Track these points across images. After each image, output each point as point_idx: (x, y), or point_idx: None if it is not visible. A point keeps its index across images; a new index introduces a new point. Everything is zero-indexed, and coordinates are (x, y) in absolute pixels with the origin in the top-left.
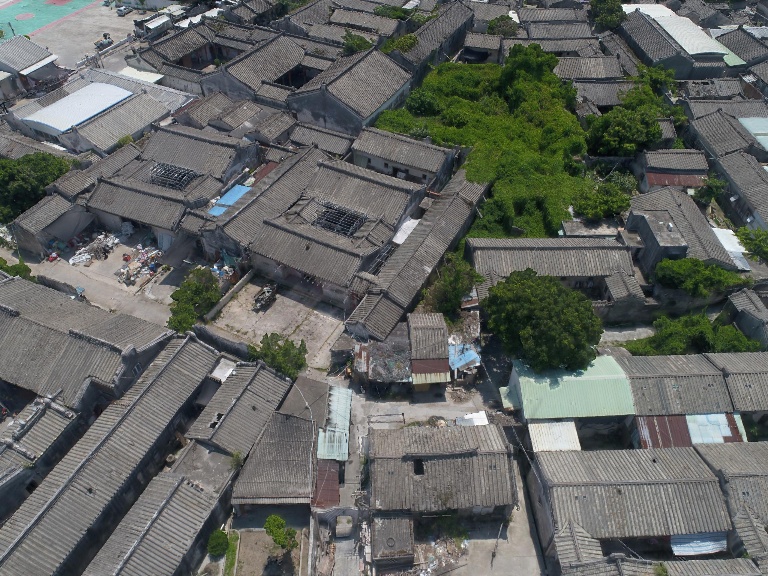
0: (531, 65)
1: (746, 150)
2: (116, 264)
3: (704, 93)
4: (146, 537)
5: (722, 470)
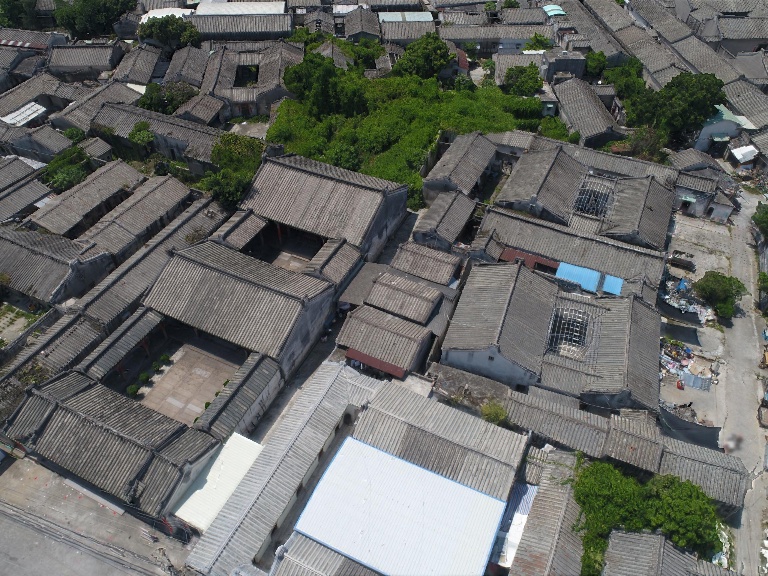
0: (331, 69)
1: None
2: (693, 395)
3: (331, 28)
4: None
5: None
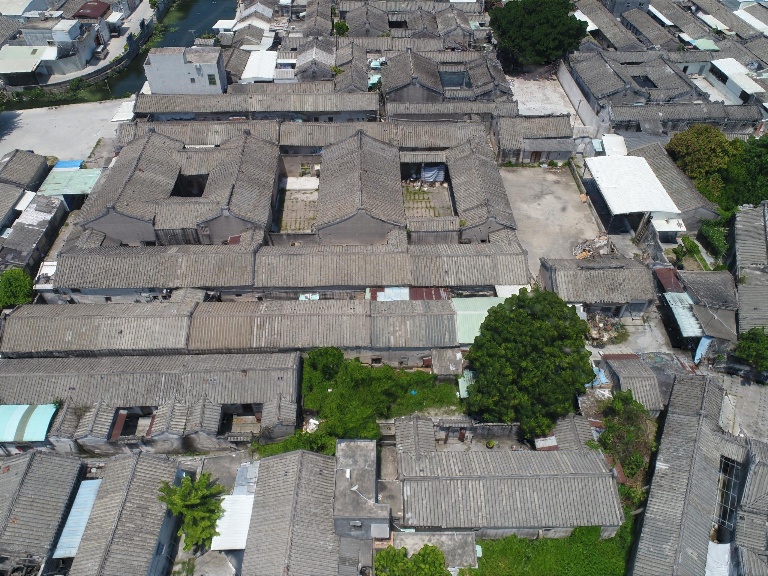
0: None
1: None
2: None
3: None
4: (765, 239)
5: None
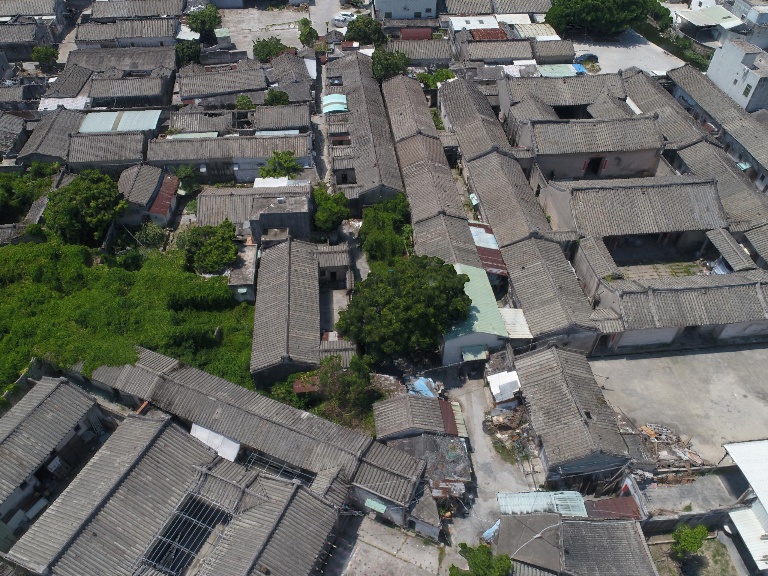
0: None
1: (145, 139)
2: None
3: (8, 142)
4: None
5: (532, 232)
